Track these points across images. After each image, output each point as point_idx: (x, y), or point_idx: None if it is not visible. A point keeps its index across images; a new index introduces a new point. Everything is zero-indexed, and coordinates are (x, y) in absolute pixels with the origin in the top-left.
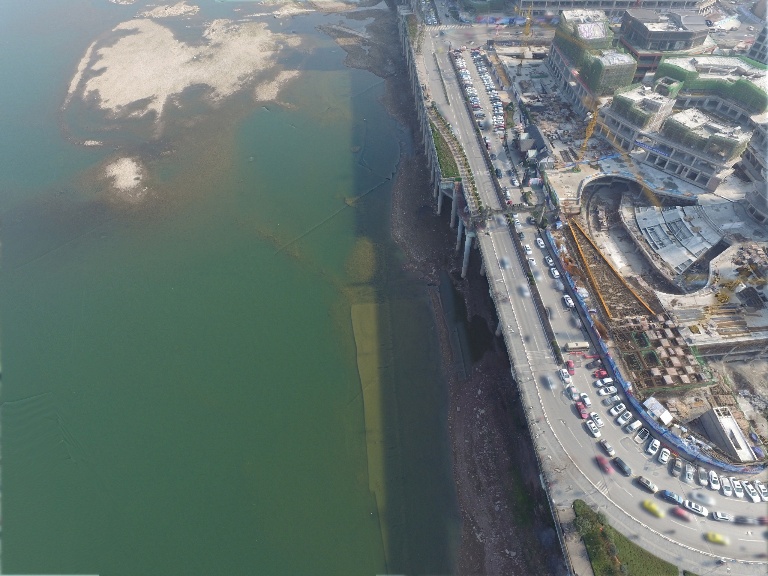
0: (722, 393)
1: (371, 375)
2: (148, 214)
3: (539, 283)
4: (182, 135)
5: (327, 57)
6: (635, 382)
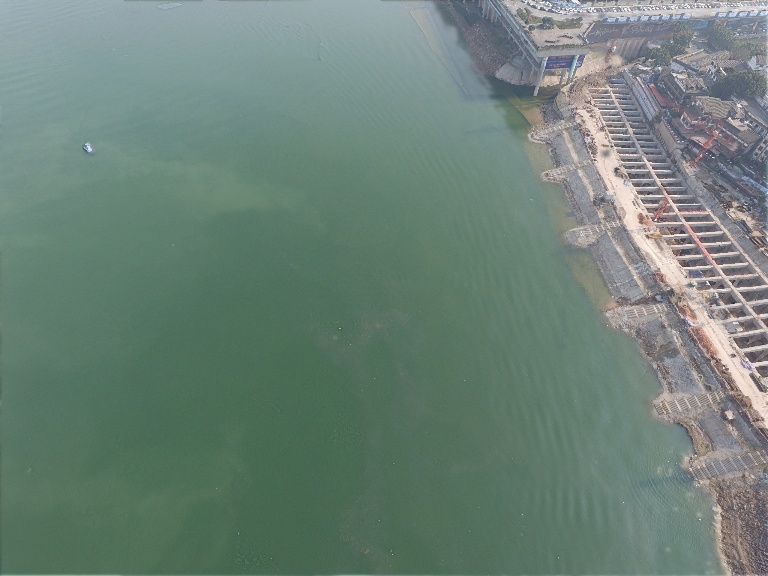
0: None
1: (425, 28)
2: None
3: None
4: None
5: None
6: None
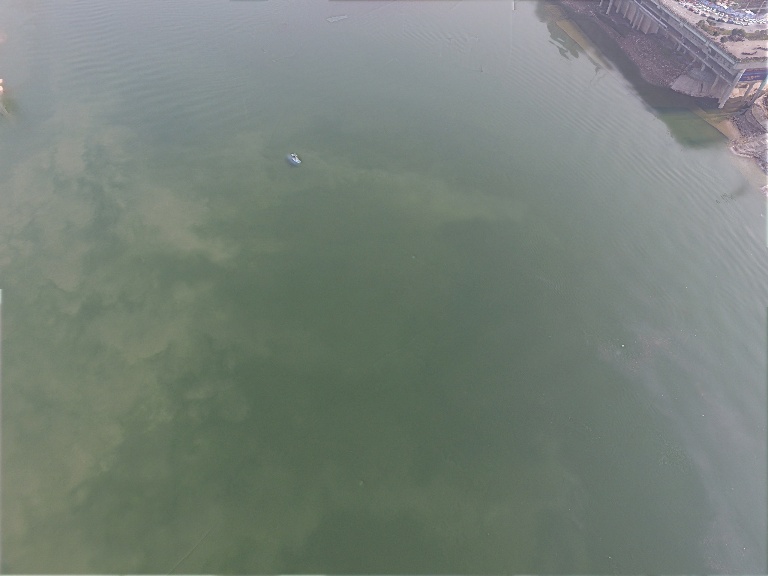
0: None
1: (578, 39)
2: None
3: None
4: None
5: None
6: None
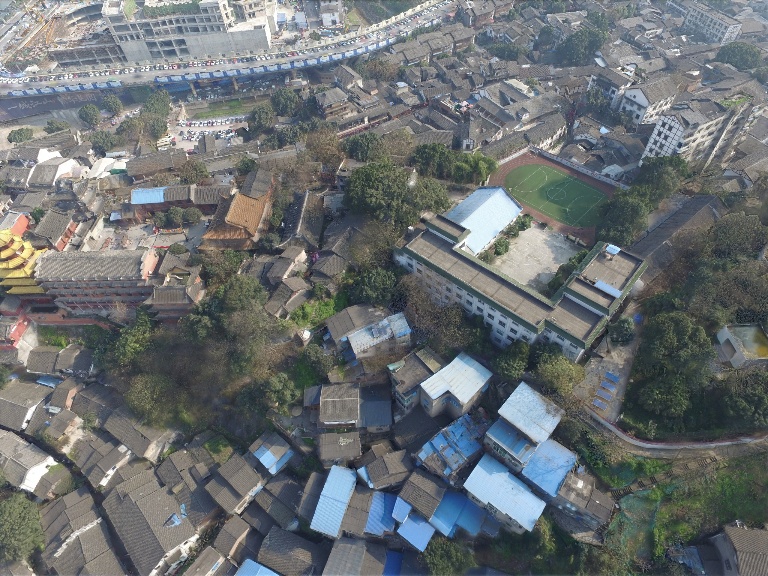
0: None
1: None
2: None
3: (5, 38)
4: None
5: None
6: (9, 62)
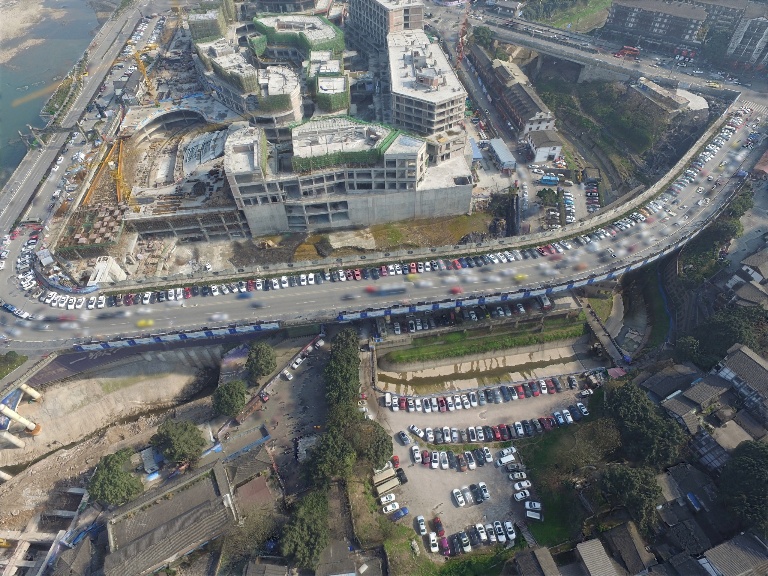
0: (152, 256)
1: None
2: None
3: (48, 183)
4: None
5: (79, 28)
6: (62, 244)
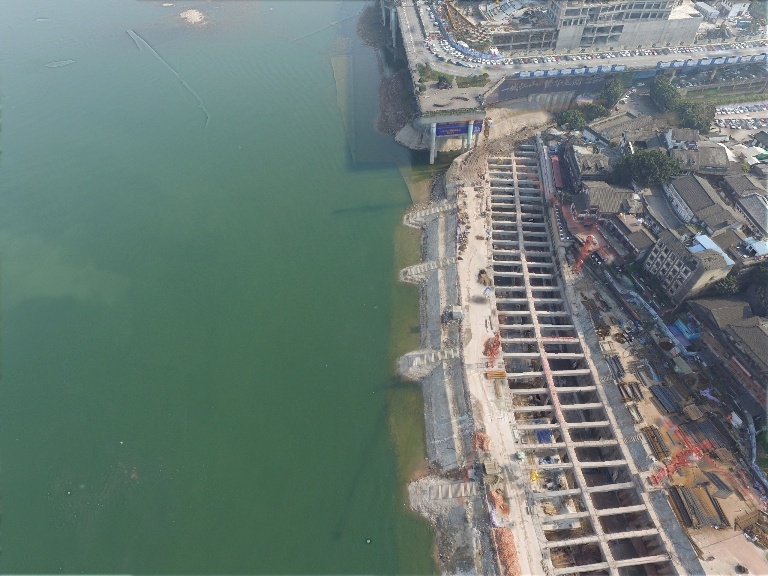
0: None
1: (341, 78)
2: (211, 31)
3: (424, 20)
4: (225, 0)
5: None
6: None
